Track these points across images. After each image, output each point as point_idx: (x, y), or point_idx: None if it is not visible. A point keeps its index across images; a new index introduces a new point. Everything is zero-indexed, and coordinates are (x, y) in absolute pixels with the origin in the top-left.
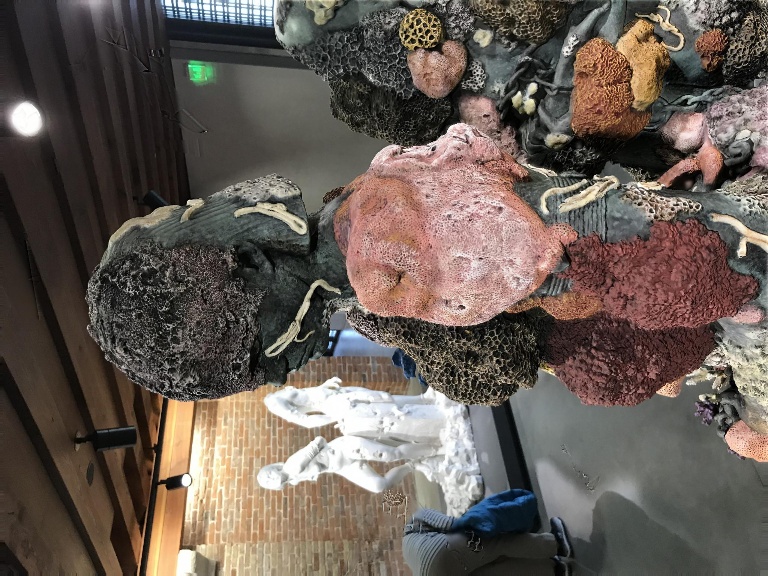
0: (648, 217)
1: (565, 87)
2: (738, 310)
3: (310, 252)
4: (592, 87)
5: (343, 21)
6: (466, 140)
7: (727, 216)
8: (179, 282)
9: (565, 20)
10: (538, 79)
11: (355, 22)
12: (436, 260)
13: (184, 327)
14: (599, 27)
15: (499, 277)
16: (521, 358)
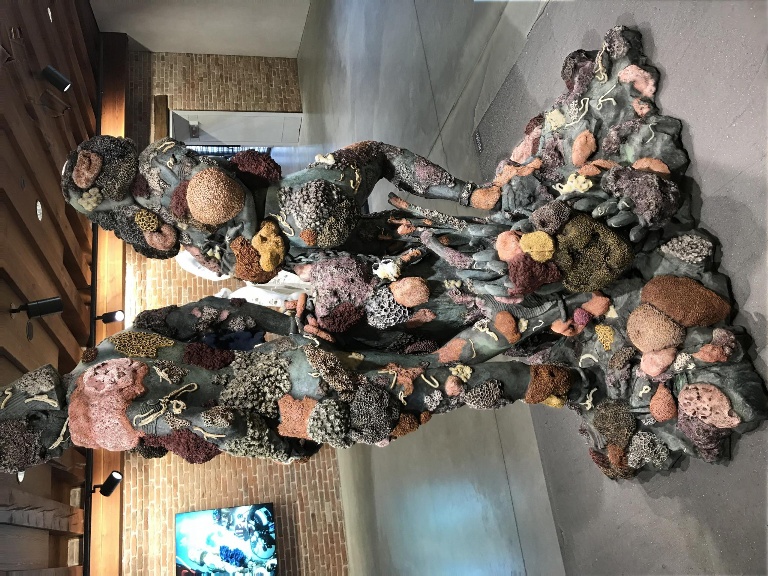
0: (170, 428)
1: None
2: (217, 448)
3: (64, 406)
4: None
5: (103, 208)
6: (114, 381)
7: (198, 428)
8: (2, 439)
9: None
10: (218, 246)
11: (110, 208)
12: (95, 442)
13: (7, 455)
14: (241, 232)
15: (120, 446)
16: (151, 452)
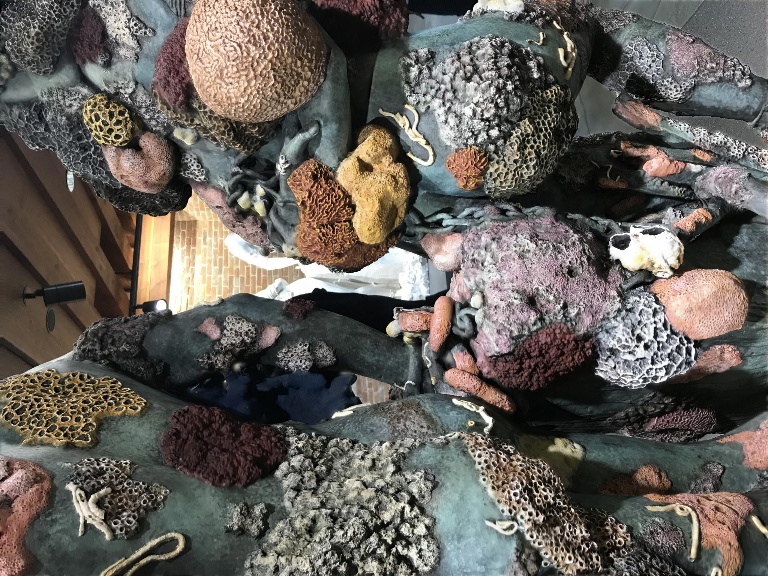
0: None
1: (291, 200)
2: None
3: None
4: None
5: (19, 93)
6: None
7: None
8: None
9: (274, 132)
10: (262, 185)
11: (34, 95)
12: None
13: None
14: (313, 148)
15: None
16: None
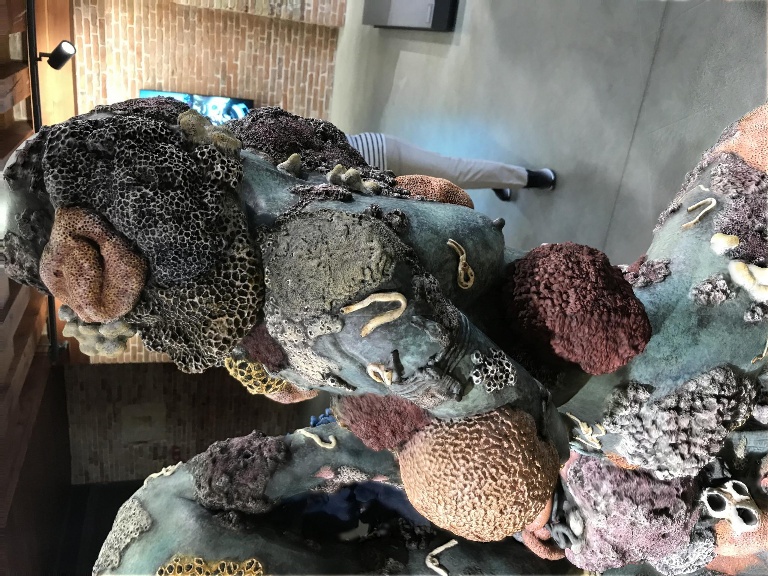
0: None
1: None
2: None
3: None
4: None
5: None
6: None
7: None
8: None
9: None
10: None
11: None
12: None
13: None
14: None
15: None
16: None
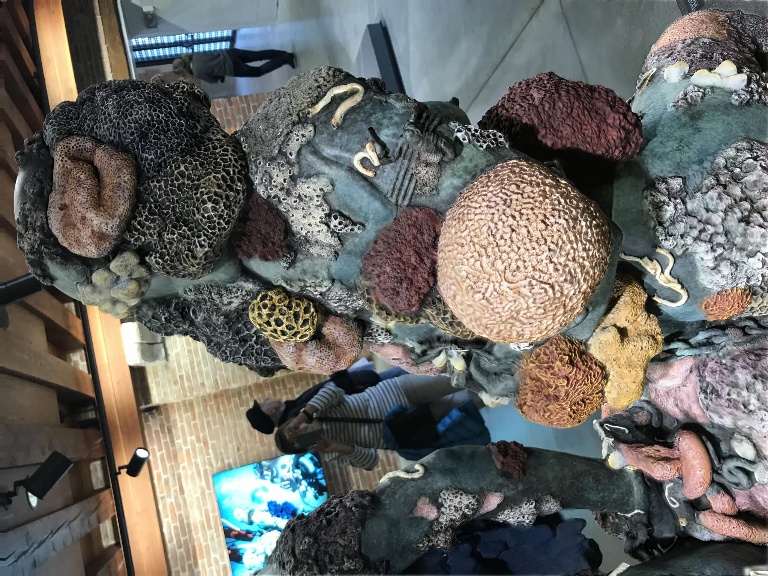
0: None
1: (509, 361)
2: None
3: None
4: (549, 400)
5: (151, 292)
6: None
7: None
8: None
9: None
10: None
11: (172, 292)
12: None
13: None
14: None
15: None
16: None
